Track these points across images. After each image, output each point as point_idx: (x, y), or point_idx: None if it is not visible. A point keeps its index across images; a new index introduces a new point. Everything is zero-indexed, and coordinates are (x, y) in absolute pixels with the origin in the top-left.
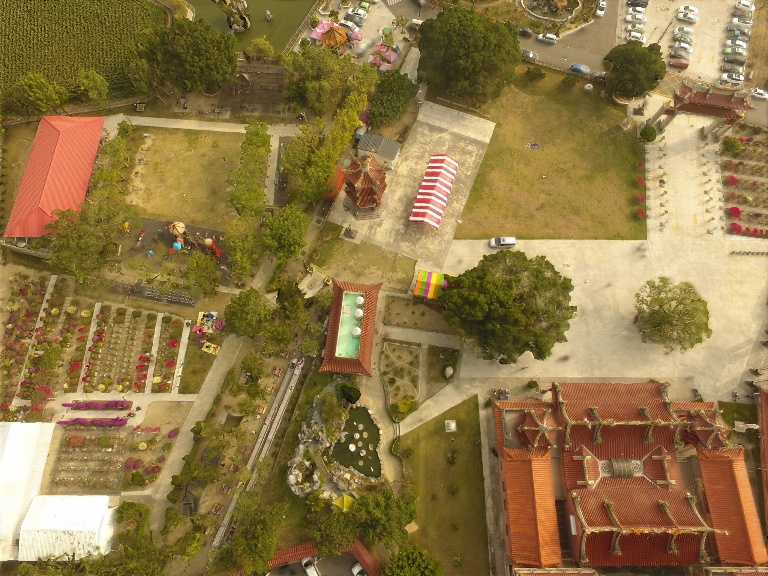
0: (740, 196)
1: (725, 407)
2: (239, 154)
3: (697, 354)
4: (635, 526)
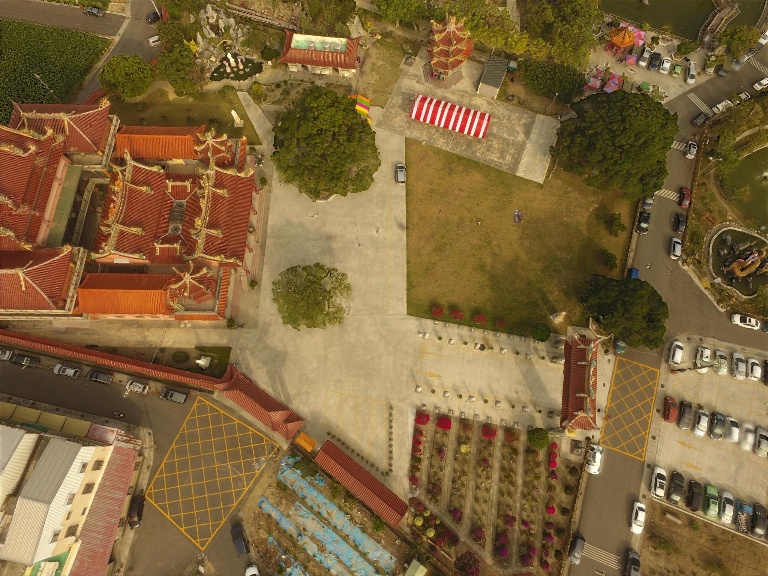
0: (468, 439)
1: (224, 351)
2: None
3: (280, 339)
4: None
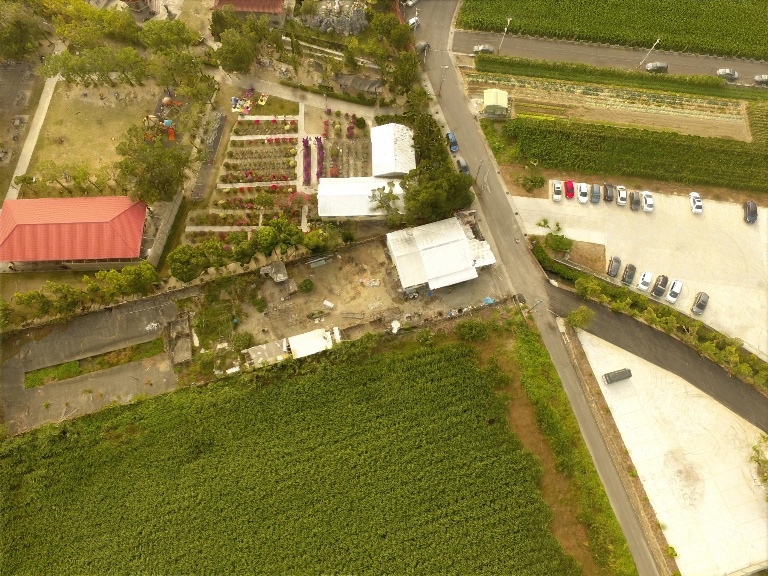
0: None
1: None
2: (75, 102)
3: None
4: None
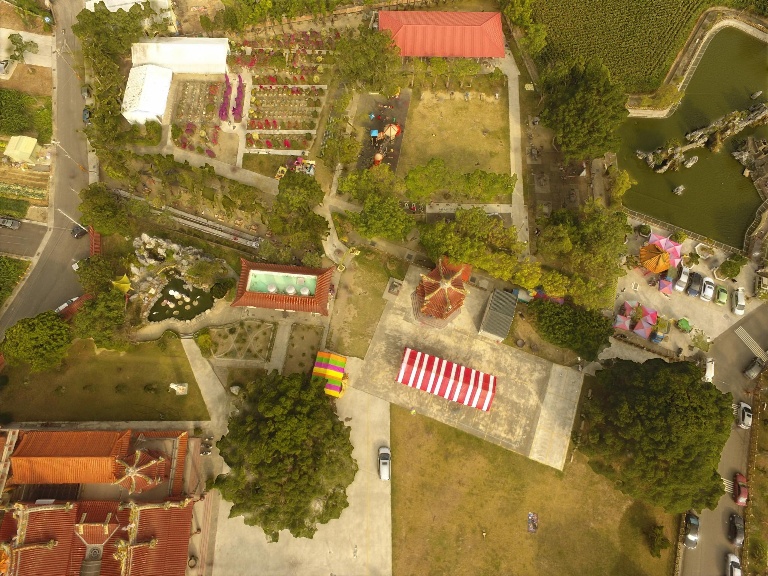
0: None
1: None
2: None
3: None
4: (16, 569)
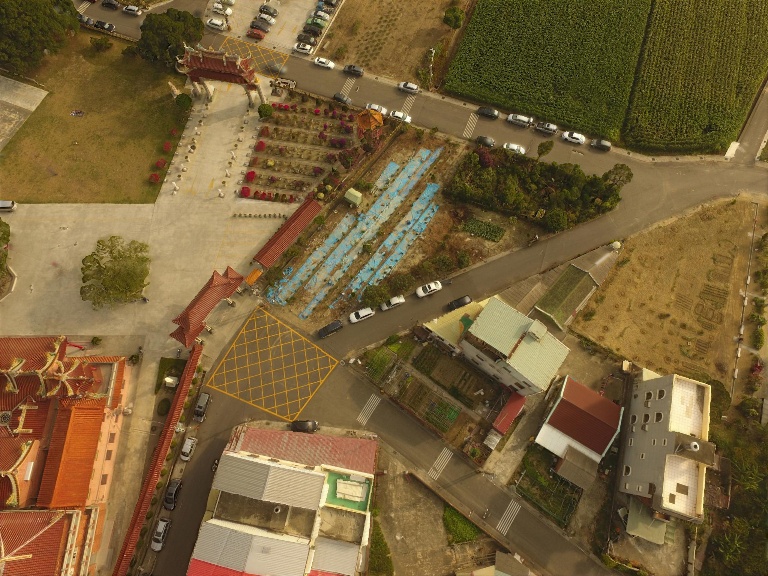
0: (265, 161)
1: (163, 363)
2: None
3: (160, 313)
4: None
